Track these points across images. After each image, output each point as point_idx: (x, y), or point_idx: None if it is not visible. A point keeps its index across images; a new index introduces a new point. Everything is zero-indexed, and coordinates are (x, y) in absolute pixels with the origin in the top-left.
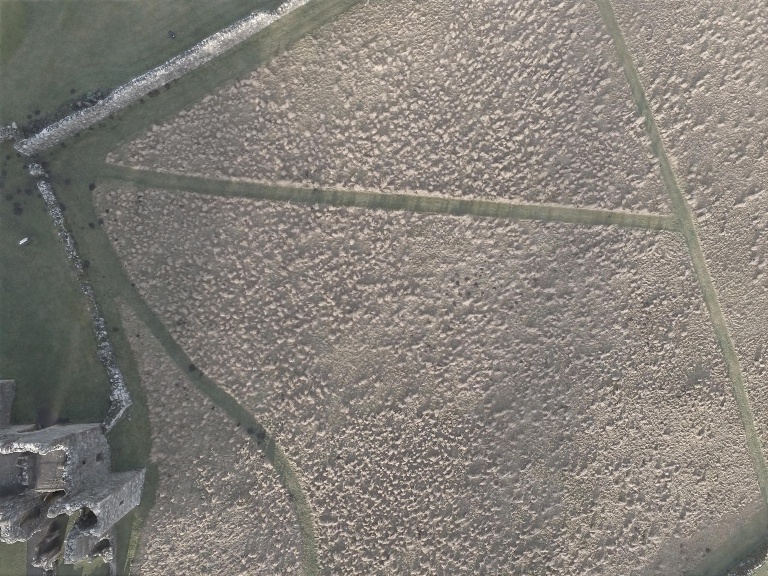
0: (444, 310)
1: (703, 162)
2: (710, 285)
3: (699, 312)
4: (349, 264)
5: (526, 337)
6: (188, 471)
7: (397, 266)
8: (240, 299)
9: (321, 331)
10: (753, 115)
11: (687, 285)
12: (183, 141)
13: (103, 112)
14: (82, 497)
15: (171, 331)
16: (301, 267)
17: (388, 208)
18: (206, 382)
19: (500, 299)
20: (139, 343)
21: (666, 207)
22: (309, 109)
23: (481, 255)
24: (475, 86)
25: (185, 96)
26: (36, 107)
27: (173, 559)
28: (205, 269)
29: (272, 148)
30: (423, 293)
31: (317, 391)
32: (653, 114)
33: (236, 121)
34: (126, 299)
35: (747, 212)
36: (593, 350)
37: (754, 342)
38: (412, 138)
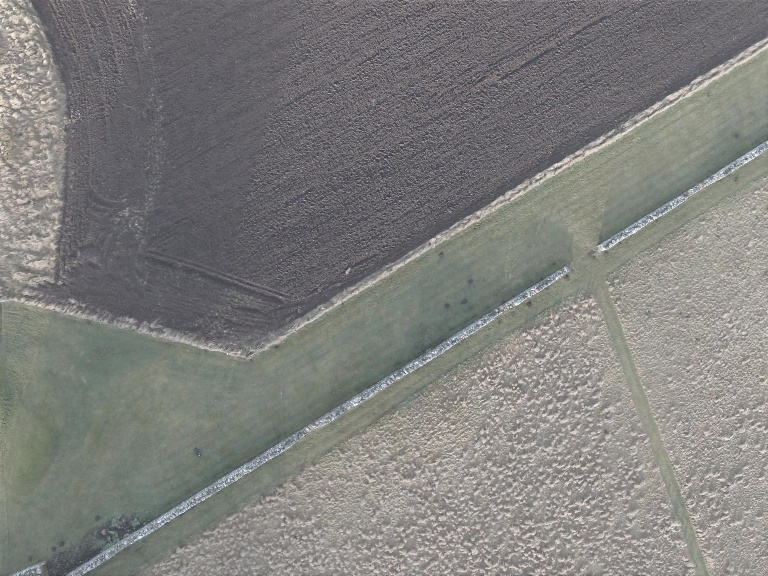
0: None
1: (740, 558)
2: None
3: None
4: None
5: None
6: None
7: None
8: None
9: None
10: None
11: None
12: (207, 562)
13: None
14: None
15: None
16: None
17: None
18: None
19: None
20: None
21: None
22: (335, 523)
23: None
24: (505, 494)
25: (210, 513)
26: (60, 538)
27: None
28: None
29: (297, 565)
30: None
31: None
32: (689, 512)
33: (261, 538)
34: None
35: None
36: None
37: None
38: (440, 552)
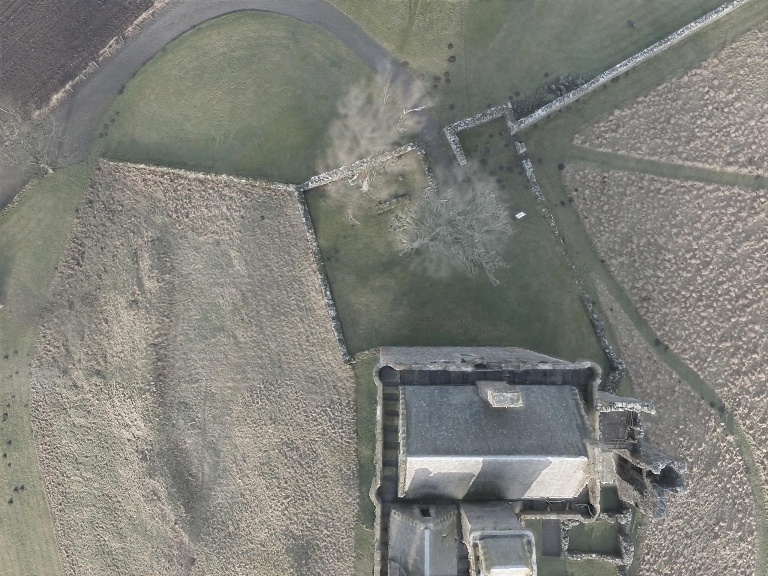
0: None
1: None
2: None
3: None
4: None
5: None
6: (672, 440)
7: None
8: (698, 278)
9: (767, 311)
10: None
11: None
12: (641, 126)
13: (579, 95)
14: (654, 457)
15: (639, 306)
16: (747, 249)
17: None
18: (670, 356)
19: None
20: (613, 317)
21: None
22: (753, 99)
23: None
24: None
25: (641, 83)
26: (516, 89)
27: (667, 523)
28: (665, 248)
29: (719, 135)
30: None
31: (766, 369)
32: None
33: (687, 108)
34: (598, 274)
35: None
36: None
37: None
38: None
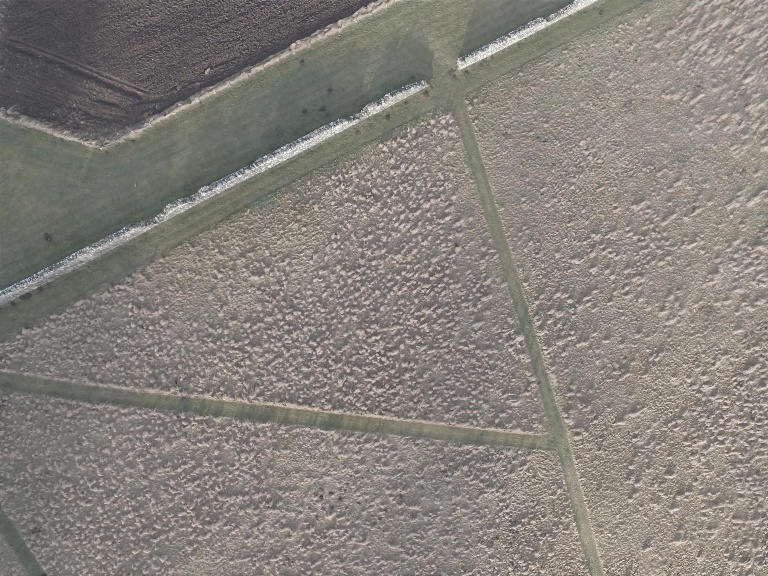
0: (306, 524)
1: (584, 379)
2: (582, 504)
3: (568, 532)
4: (212, 474)
5: (388, 553)
6: None
7: (261, 478)
8: (98, 508)
9: (179, 542)
10: (640, 332)
11: (558, 504)
12: (52, 345)
13: None
14: None
15: (25, 539)
16: (163, 476)
17: (256, 419)
18: None
19: (364, 514)
20: None
21: (541, 426)
22: (182, 316)
23: (347, 470)
24: (353, 298)
25: (58, 298)
26: None
27: None
28: (65, 476)
29: (142, 354)
30: (285, 506)
31: None
32: (535, 330)
33: (108, 325)
34: None
35: (627, 429)
36: (456, 568)
37: (624, 562)
38: (284, 350)
